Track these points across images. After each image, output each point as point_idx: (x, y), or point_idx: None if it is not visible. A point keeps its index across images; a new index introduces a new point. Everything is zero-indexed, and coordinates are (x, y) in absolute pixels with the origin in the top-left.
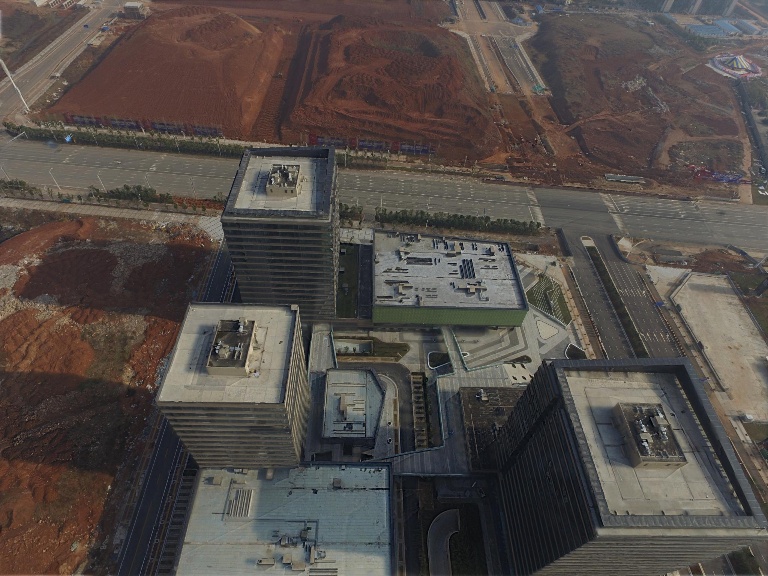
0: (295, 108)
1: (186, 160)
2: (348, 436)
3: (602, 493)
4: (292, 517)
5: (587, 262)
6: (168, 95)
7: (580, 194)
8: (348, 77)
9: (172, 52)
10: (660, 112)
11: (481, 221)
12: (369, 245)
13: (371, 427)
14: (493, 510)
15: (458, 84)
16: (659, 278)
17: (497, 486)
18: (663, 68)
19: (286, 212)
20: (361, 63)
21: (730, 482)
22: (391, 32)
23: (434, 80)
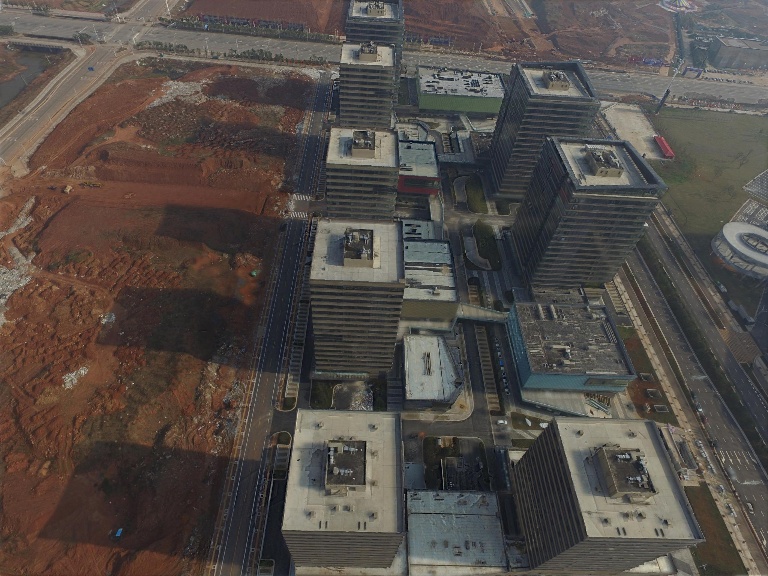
0: None
1: (285, 42)
2: None
3: (532, 89)
4: None
5: None
6: (265, 6)
7: None
8: None
9: None
10: (615, 29)
11: None
12: (414, 78)
13: None
14: (488, 174)
15: (469, 5)
16: None
17: (490, 167)
18: (622, 4)
19: (381, 18)
20: None
21: (588, 94)
22: None
23: (452, 1)
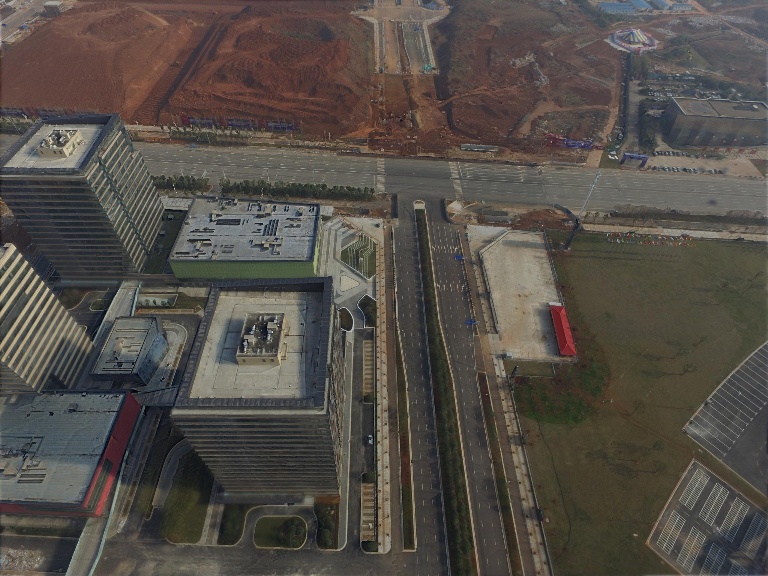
0: (175, 92)
1: None
2: (115, 373)
3: (189, 382)
4: (22, 434)
5: (411, 223)
6: (58, 84)
7: (429, 163)
8: (231, 62)
9: (69, 45)
10: (539, 86)
11: (316, 188)
12: None
13: (139, 365)
14: None
15: (339, 65)
16: (471, 235)
17: None
18: (557, 44)
19: (44, 169)
20: (248, 49)
21: None
22: (293, 20)
23: (314, 62)
